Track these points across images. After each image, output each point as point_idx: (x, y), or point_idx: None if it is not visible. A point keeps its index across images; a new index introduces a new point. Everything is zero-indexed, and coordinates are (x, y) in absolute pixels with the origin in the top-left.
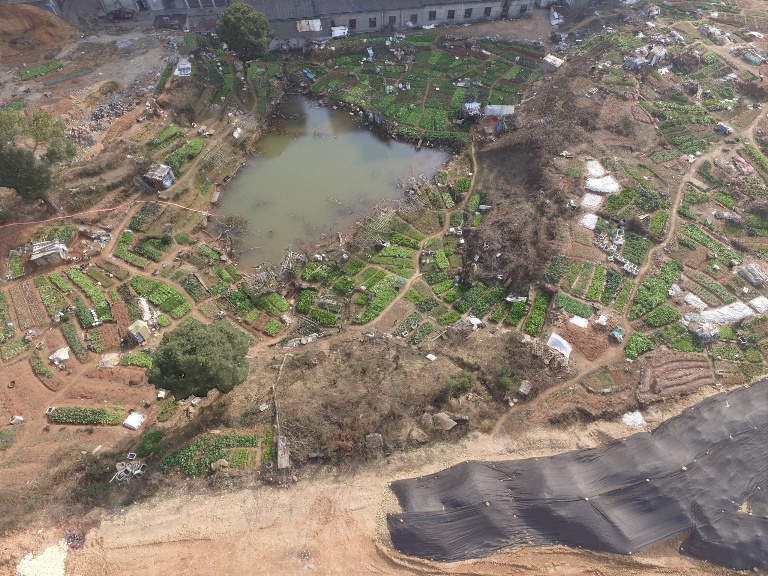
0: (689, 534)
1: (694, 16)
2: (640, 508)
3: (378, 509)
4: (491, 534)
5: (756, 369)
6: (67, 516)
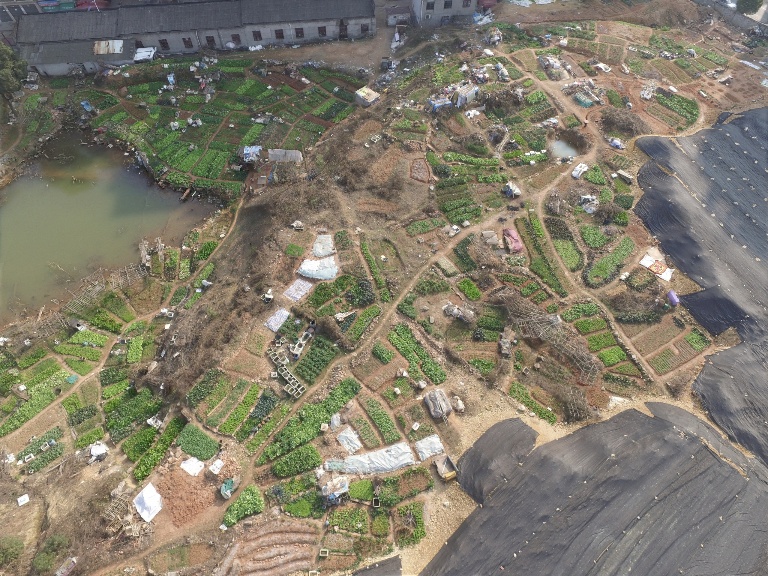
0: None
1: (541, 43)
2: None
3: None
4: None
5: (374, 548)
6: None
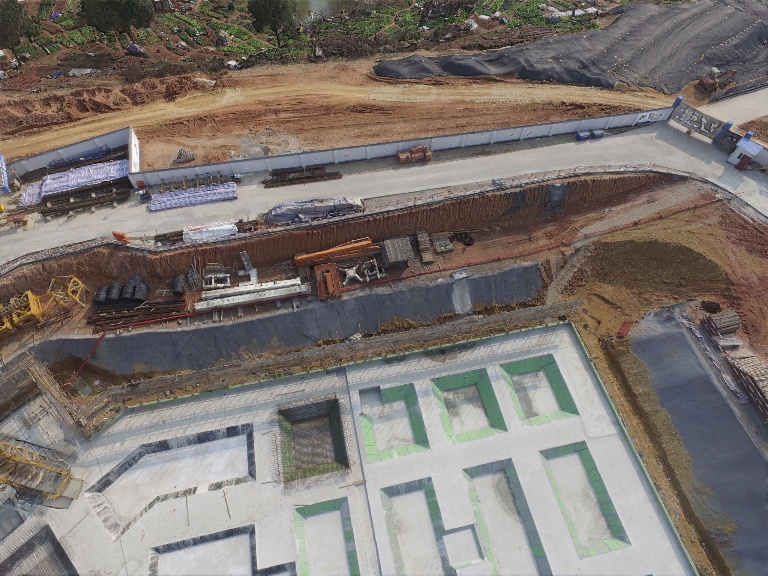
0: (522, 69)
1: None
2: (500, 65)
3: (368, 68)
4: (425, 72)
5: (578, 30)
6: (210, 72)
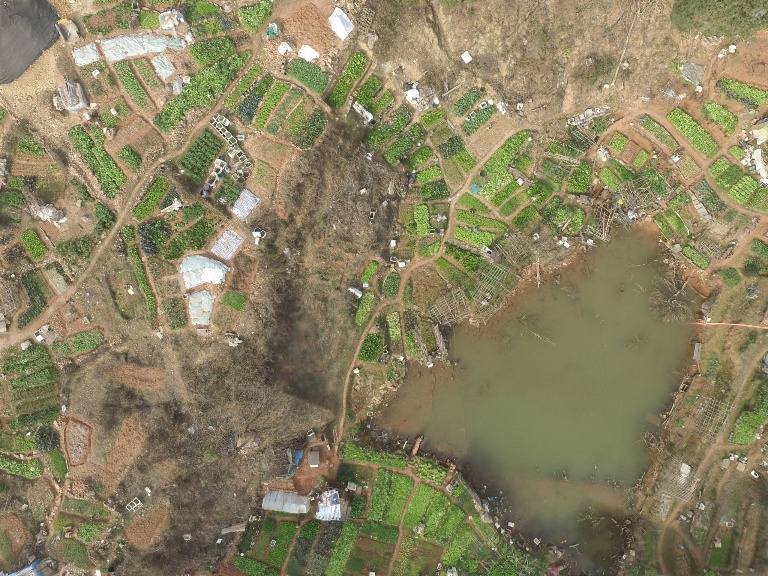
0: None
1: None
2: None
3: None
4: None
5: None
6: None
